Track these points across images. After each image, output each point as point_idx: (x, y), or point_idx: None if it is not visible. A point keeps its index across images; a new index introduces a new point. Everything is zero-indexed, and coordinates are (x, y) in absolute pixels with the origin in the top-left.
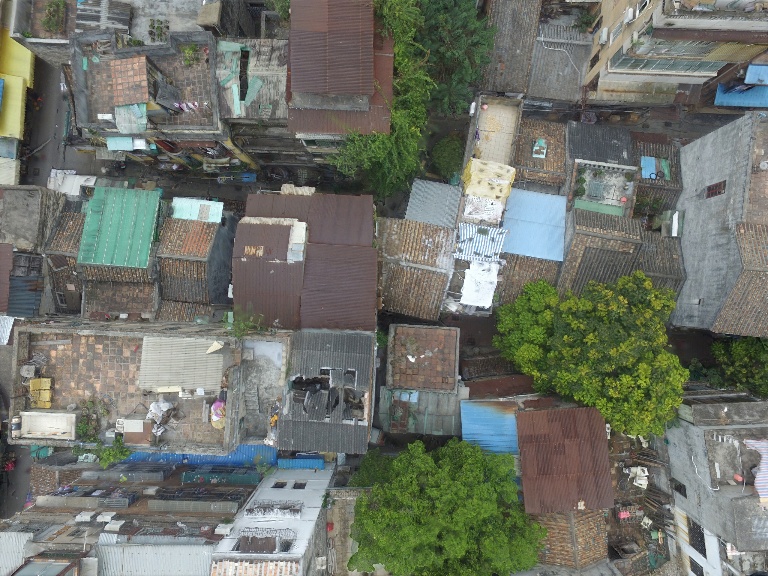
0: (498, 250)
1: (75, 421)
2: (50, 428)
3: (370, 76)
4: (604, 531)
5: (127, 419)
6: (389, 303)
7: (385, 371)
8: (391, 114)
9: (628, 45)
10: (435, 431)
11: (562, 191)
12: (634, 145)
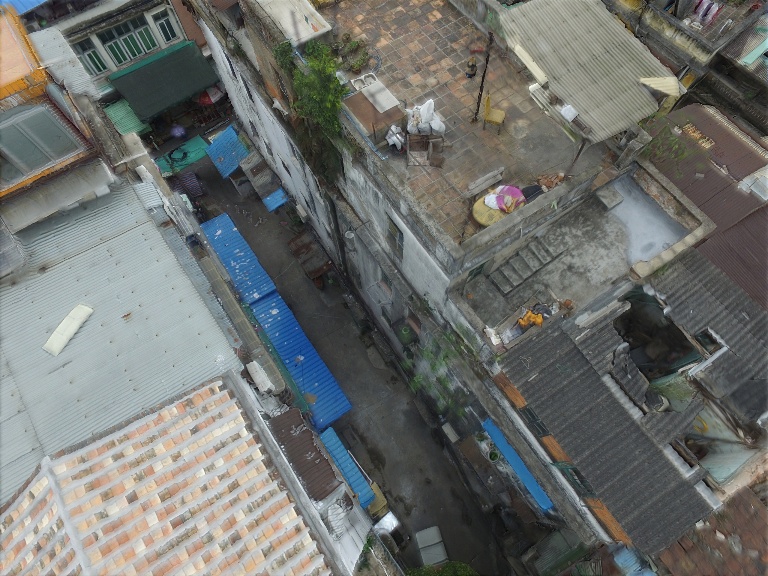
0: None
1: (321, 33)
2: None
3: None
4: None
5: None
6: None
7: None
8: None
9: None
10: None
11: None
12: None
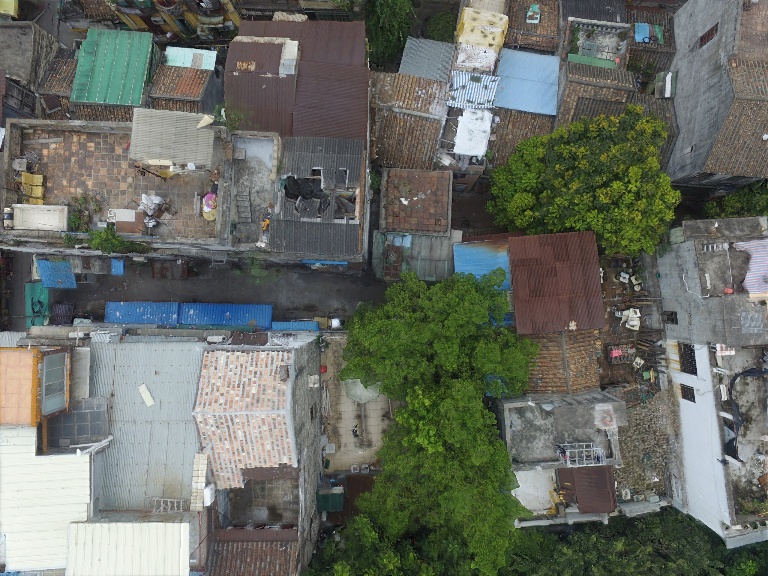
0: (491, 97)
1: (67, 213)
2: (42, 225)
3: None
4: (596, 362)
5: (119, 209)
6: (382, 156)
7: (378, 218)
8: None
9: None
10: (428, 277)
11: (556, 55)
12: (628, 13)
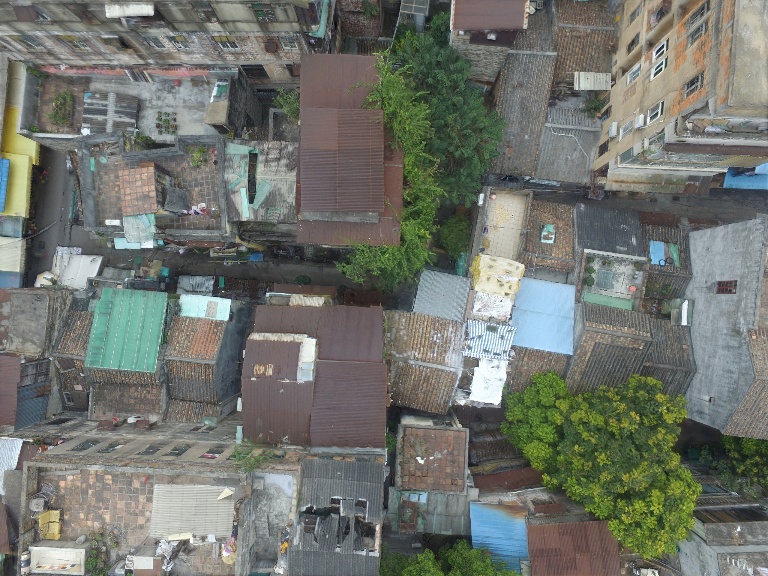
0: (507, 348)
1: (84, 556)
2: (59, 560)
3: (380, 193)
4: None
5: (137, 556)
6: (397, 397)
7: (394, 469)
8: (401, 225)
9: (639, 150)
10: (444, 531)
11: (571, 277)
12: (643, 229)
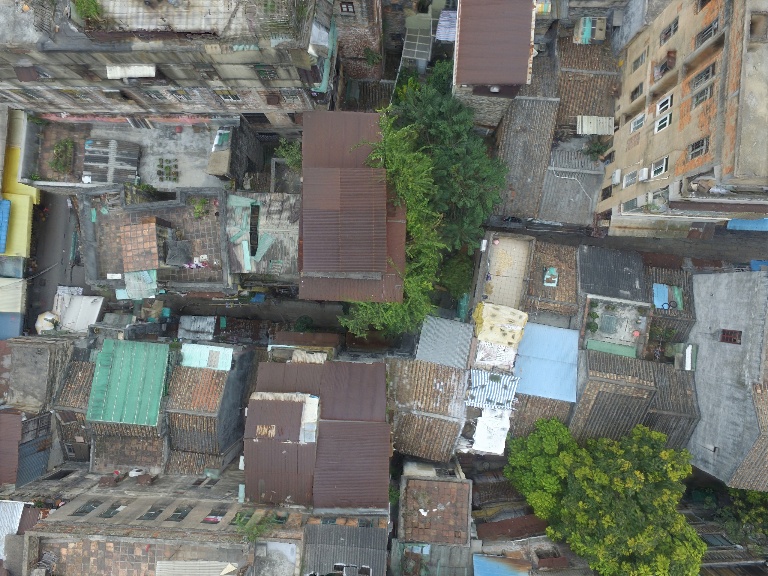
0: (511, 398)
1: None
2: None
3: (383, 253)
4: None
5: None
6: (400, 445)
7: (396, 520)
8: (404, 282)
9: (643, 202)
10: None
11: (574, 321)
12: (646, 271)
